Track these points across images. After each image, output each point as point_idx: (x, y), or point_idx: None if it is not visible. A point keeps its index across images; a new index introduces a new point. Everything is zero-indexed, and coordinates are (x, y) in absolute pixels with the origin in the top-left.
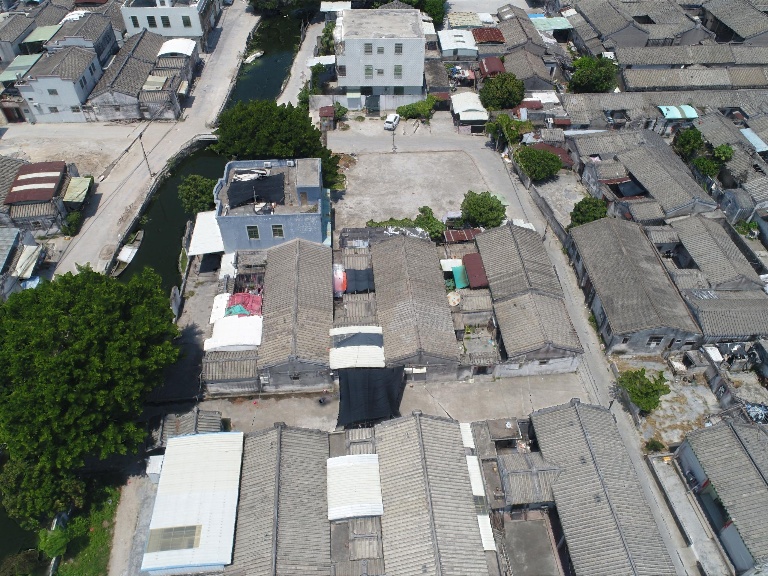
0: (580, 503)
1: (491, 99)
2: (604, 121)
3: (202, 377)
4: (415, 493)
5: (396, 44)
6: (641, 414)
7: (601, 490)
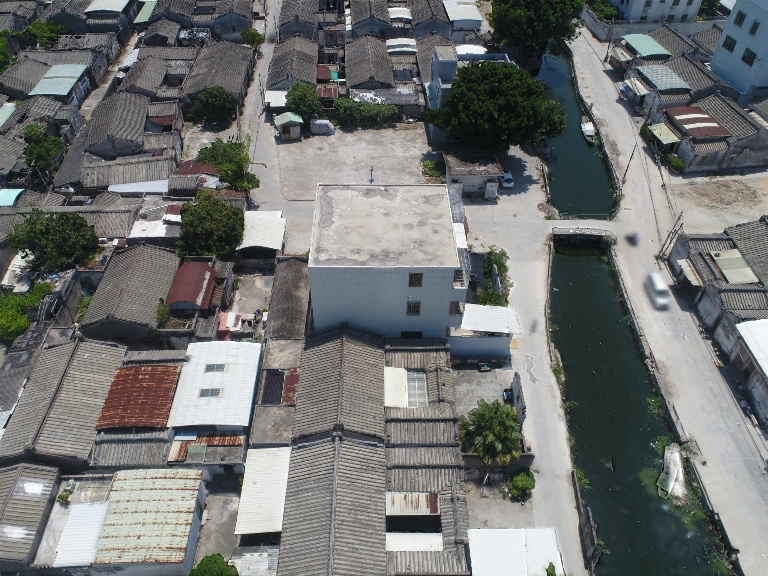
0: (310, 6)
1: None
2: None
3: None
4: (375, 6)
5: None
6: None
7: (301, 4)
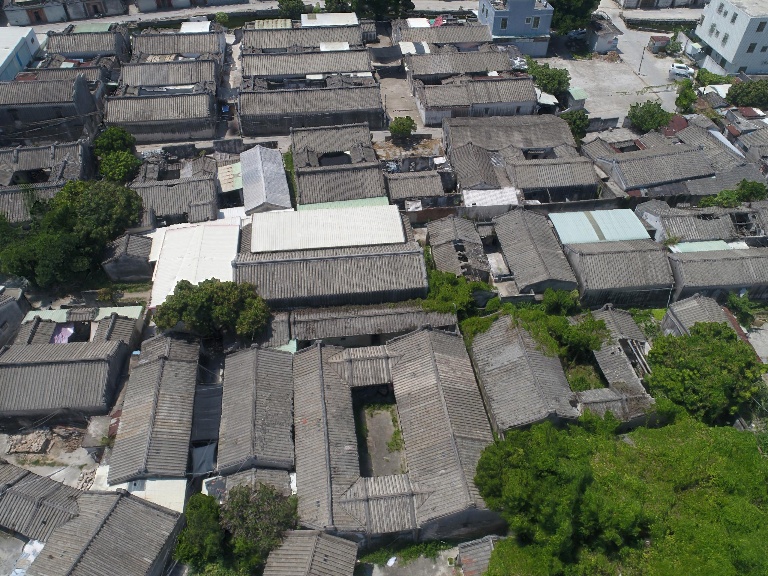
0: None
1: (732, 88)
2: (759, 154)
3: (392, 21)
4: None
5: (735, 13)
6: (394, 141)
7: None
